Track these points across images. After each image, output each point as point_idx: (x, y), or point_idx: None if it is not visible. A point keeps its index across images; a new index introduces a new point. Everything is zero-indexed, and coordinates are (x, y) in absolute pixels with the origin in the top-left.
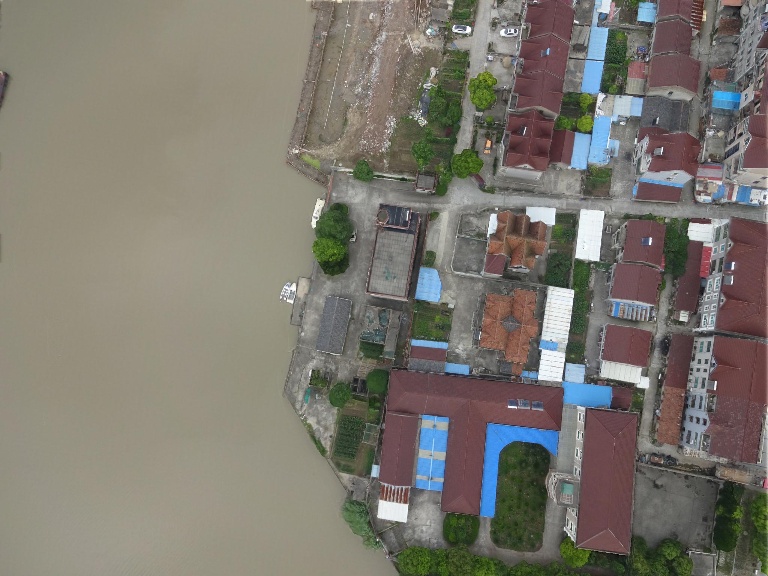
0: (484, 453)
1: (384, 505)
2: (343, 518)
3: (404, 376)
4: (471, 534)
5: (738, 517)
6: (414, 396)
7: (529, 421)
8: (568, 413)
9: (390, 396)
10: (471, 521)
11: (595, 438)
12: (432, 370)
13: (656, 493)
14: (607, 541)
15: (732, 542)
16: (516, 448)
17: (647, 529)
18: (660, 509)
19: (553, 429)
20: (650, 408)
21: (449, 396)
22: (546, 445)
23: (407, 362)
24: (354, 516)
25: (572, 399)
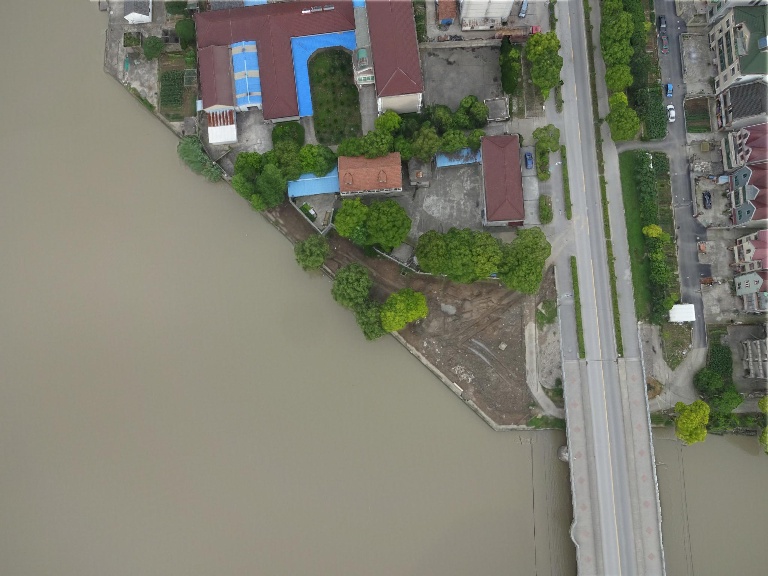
0: (293, 63)
1: (213, 131)
2: (183, 165)
3: (207, 14)
4: (298, 139)
5: (515, 56)
6: (218, 25)
7: (326, 26)
8: (359, 12)
9: (198, 35)
10: (295, 127)
11: (375, 3)
12: (233, 6)
13: (451, 69)
14: (401, 82)
15: (512, 74)
16: (323, 60)
17: (449, 99)
18: (457, 81)
19: (349, 29)
20: (432, 1)
21: (249, 17)
22: (346, 45)
23: (210, 6)
24: (188, 148)
25: (361, 2)
